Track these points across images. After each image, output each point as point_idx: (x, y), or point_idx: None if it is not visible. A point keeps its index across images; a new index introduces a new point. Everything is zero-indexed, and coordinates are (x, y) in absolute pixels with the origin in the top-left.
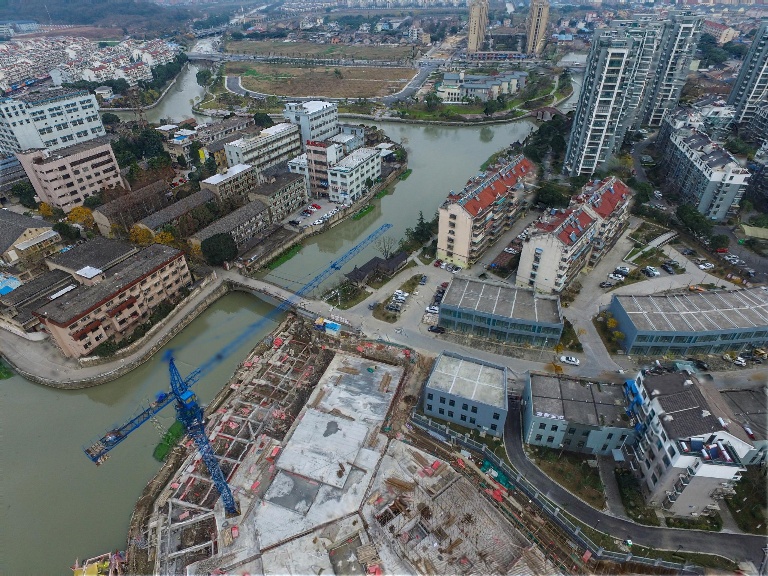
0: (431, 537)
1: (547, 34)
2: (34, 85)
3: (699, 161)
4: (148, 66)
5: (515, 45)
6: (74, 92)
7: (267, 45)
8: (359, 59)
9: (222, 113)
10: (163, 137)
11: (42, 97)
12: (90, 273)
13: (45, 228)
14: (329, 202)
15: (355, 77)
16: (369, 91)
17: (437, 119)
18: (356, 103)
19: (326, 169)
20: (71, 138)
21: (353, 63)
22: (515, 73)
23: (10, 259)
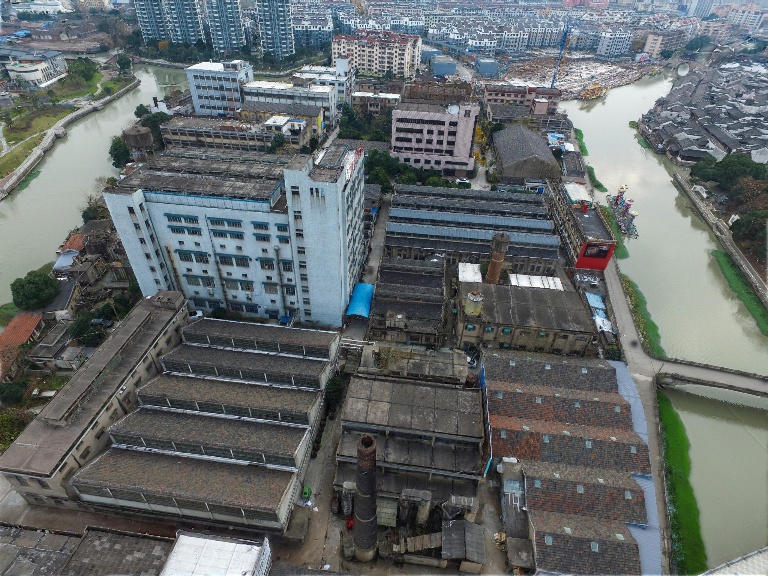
0: (527, 75)
1: None
2: None
3: (314, 27)
4: None
5: None
6: (195, 150)
7: None
8: None
9: None
10: (297, 129)
11: None
12: None
13: None
14: None
15: None
16: None
17: (123, 85)
18: (6, 115)
19: None
20: None
21: None
22: None
23: None
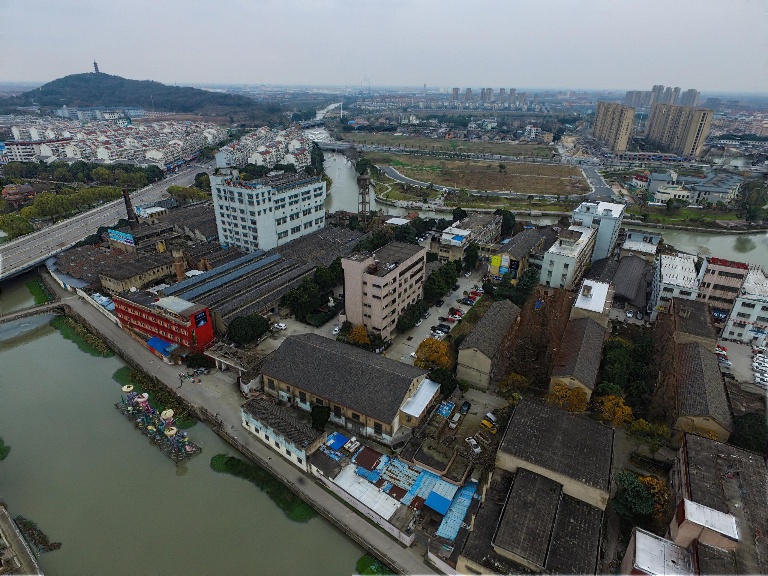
0: None
1: (711, 138)
2: (182, 166)
3: None
4: (309, 152)
5: (646, 147)
6: (309, 178)
7: (382, 137)
8: (497, 154)
9: (419, 205)
10: None
11: (280, 182)
12: (716, 522)
13: (422, 376)
14: (724, 340)
15: (518, 172)
16: (556, 188)
17: (689, 225)
18: (564, 201)
19: (737, 297)
20: (298, 229)
21: (500, 158)
22: (733, 177)
23: (393, 430)
